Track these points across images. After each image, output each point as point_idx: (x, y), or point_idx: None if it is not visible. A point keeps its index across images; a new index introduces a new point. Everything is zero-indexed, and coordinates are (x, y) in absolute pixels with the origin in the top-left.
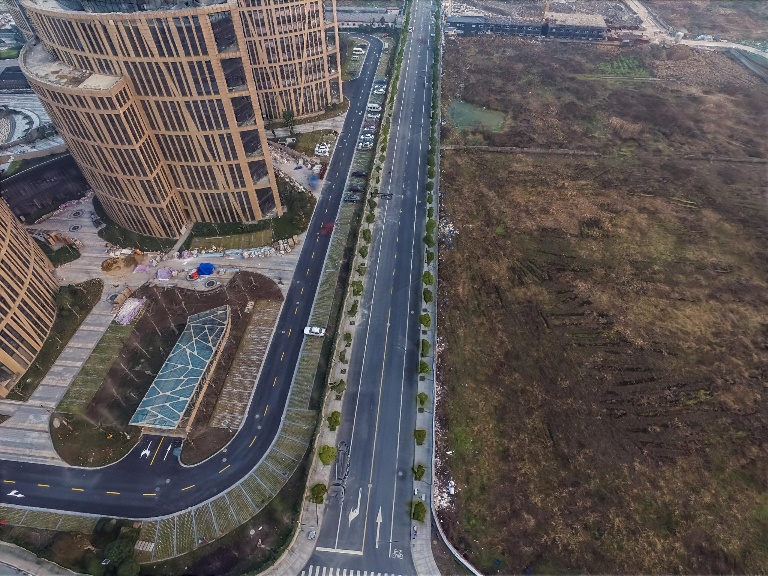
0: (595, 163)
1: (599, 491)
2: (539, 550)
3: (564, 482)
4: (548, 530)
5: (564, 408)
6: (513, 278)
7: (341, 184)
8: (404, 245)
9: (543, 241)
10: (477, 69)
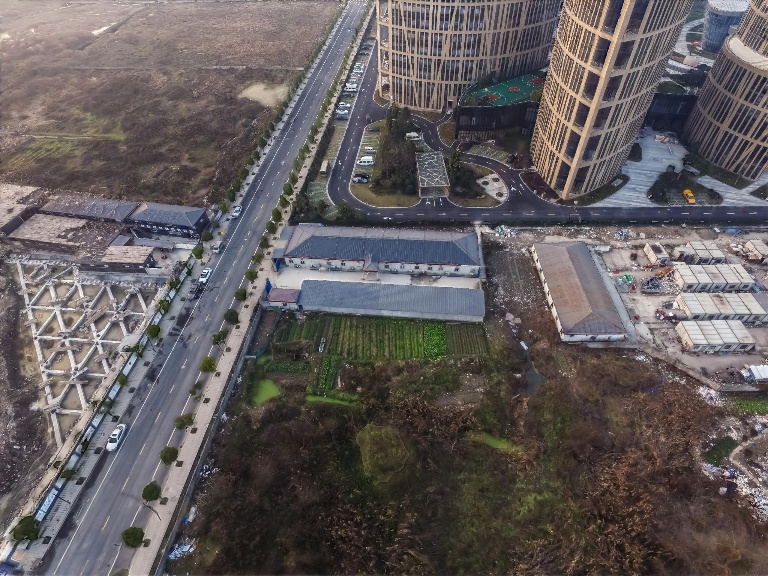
0: (210, 65)
1: (302, 6)
2: (322, 2)
3: (310, 6)
4: (318, 3)
5: (302, 12)
6: (298, 30)
7: (375, 51)
8: (342, 36)
9: (276, 38)
10: (226, 132)
